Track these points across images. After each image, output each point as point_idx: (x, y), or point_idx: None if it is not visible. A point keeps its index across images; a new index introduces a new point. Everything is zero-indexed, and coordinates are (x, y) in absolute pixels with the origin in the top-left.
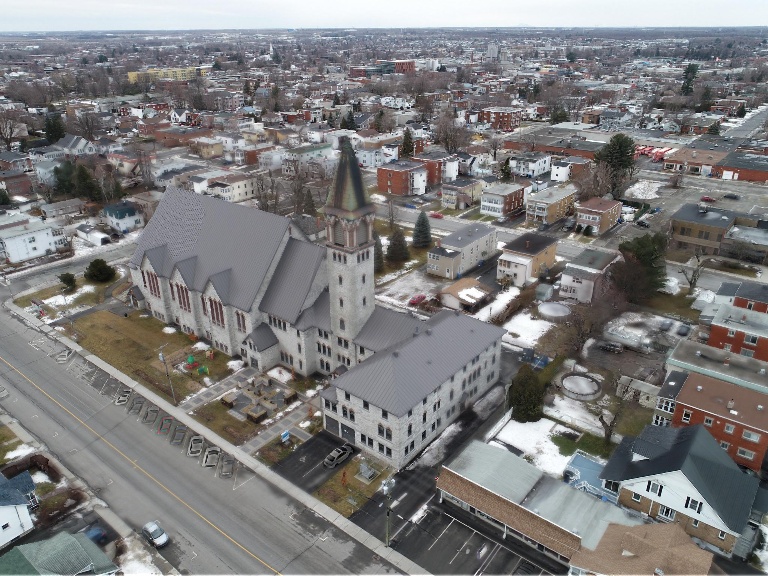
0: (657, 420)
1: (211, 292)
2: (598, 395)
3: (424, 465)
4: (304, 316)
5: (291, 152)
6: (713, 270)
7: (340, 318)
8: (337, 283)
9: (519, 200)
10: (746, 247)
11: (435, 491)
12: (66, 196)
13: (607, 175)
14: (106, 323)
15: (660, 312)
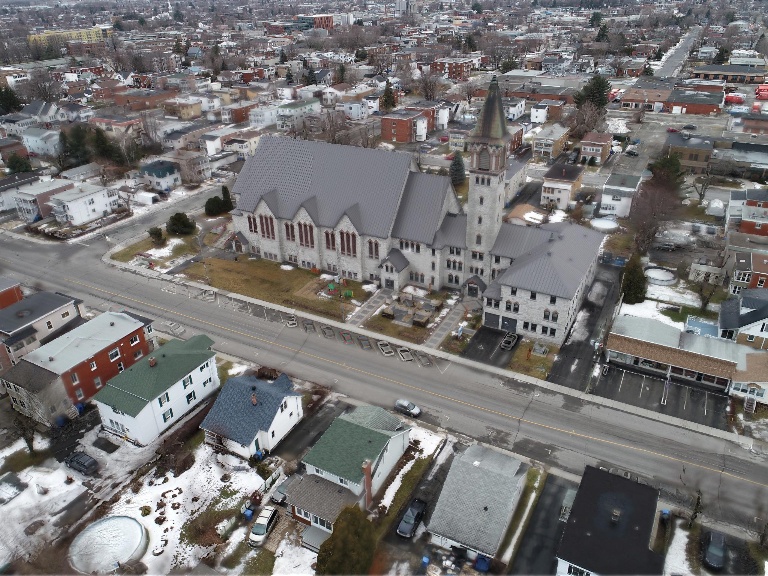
0: (735, 290)
1: (344, 225)
2: (676, 280)
3: (578, 340)
4: (437, 237)
5: (285, 107)
6: None
7: (477, 234)
8: (477, 203)
9: (520, 140)
10: (731, 164)
11: (599, 355)
12: (80, 161)
13: (592, 113)
14: (222, 267)
15: (687, 219)
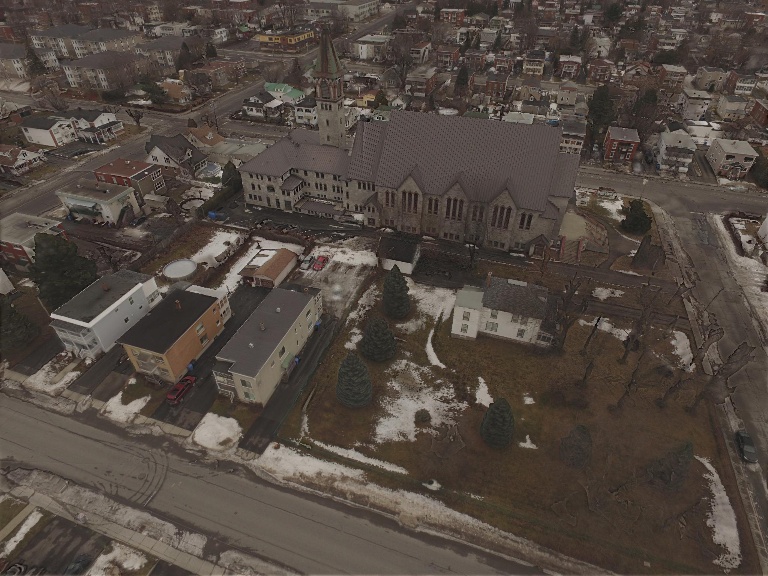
0: None
1: None
2: None
3: None
4: None
5: None
6: None
7: None
8: None
9: None
10: None
11: None
12: None
13: None
14: None
15: None
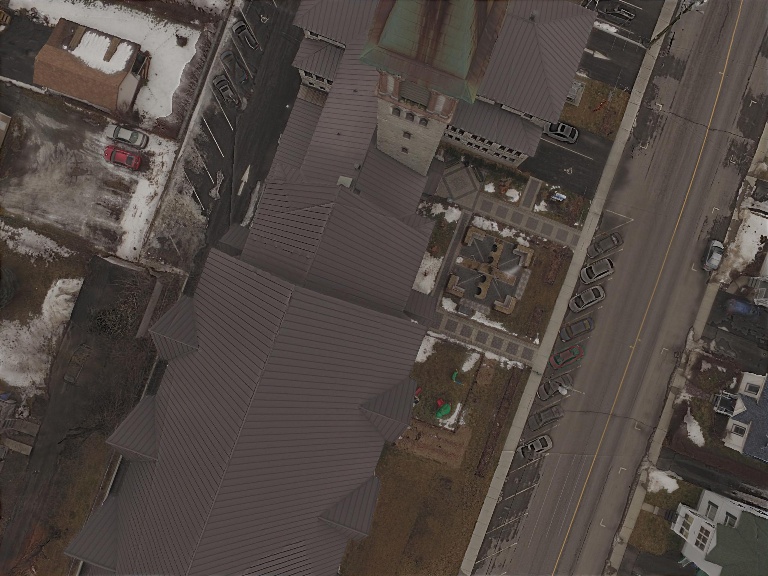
0: None
1: None
2: None
3: None
4: None
5: None
6: None
7: None
8: None
9: None
10: None
11: None
12: None
13: None
14: None
15: None
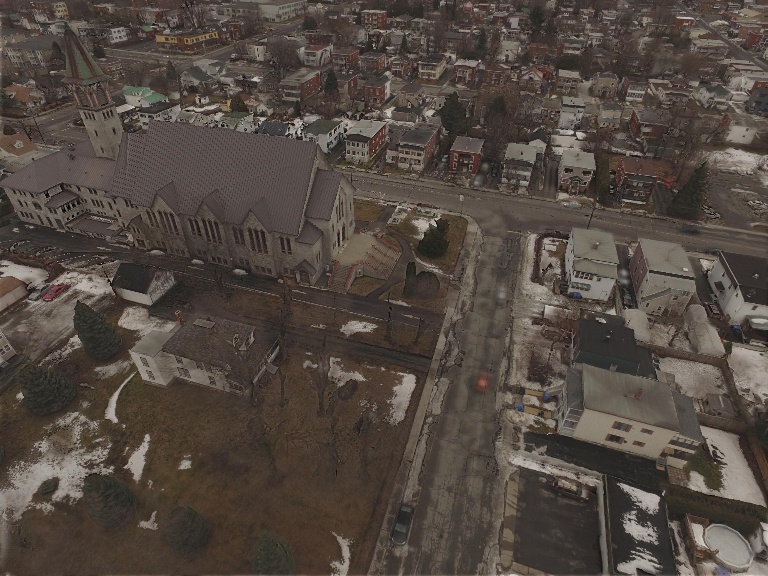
0: None
1: None
2: None
3: None
4: None
5: None
6: None
7: None
8: None
9: None
10: None
11: None
12: None
13: None
14: None
15: None
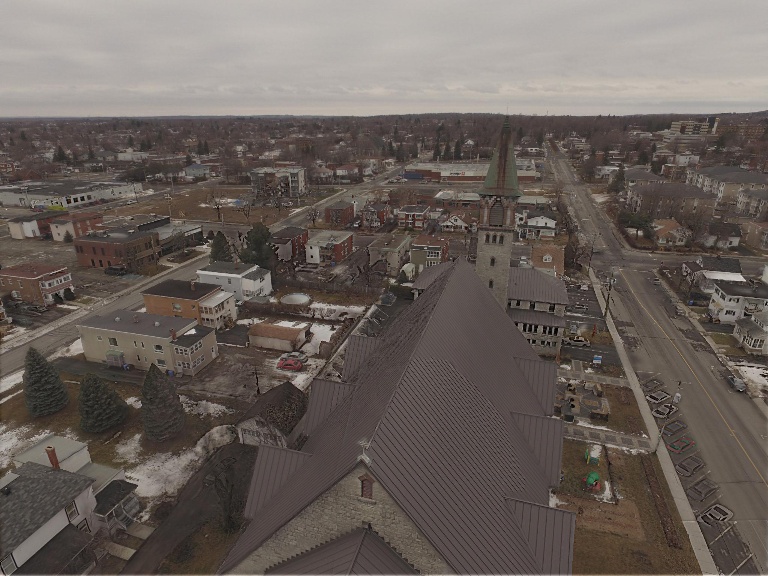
0: None
1: None
2: None
3: None
4: None
5: None
6: (190, 260)
7: None
8: None
9: None
10: None
11: None
12: None
13: None
14: None
15: None
